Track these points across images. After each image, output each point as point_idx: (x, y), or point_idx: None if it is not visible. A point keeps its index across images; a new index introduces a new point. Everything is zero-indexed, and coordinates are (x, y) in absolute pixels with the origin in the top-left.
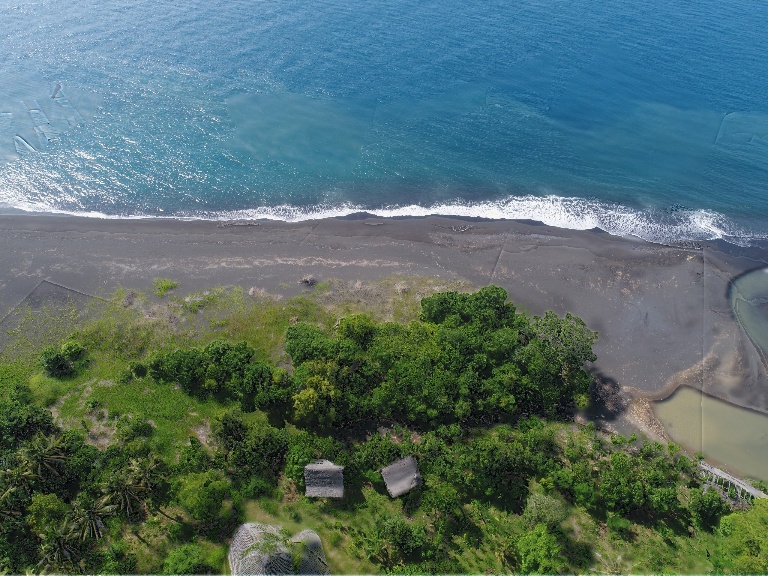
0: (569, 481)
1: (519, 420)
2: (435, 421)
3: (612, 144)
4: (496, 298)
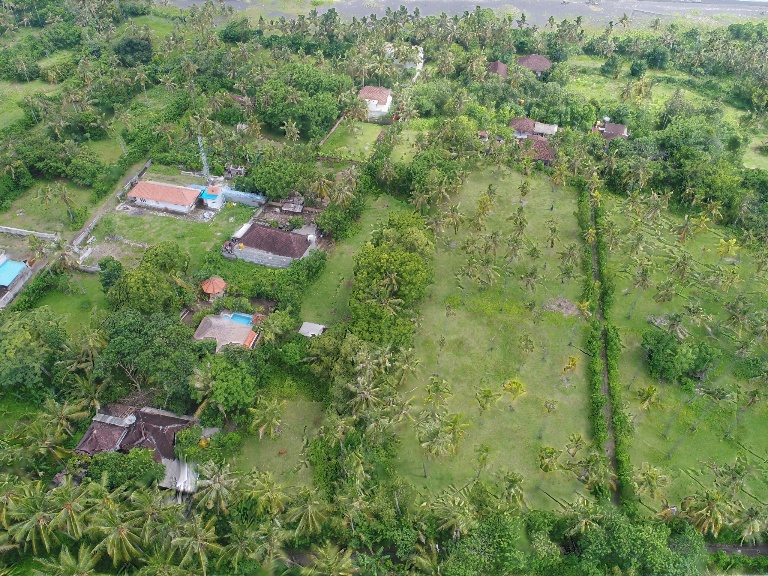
0: None
1: None
2: None
3: None
4: None
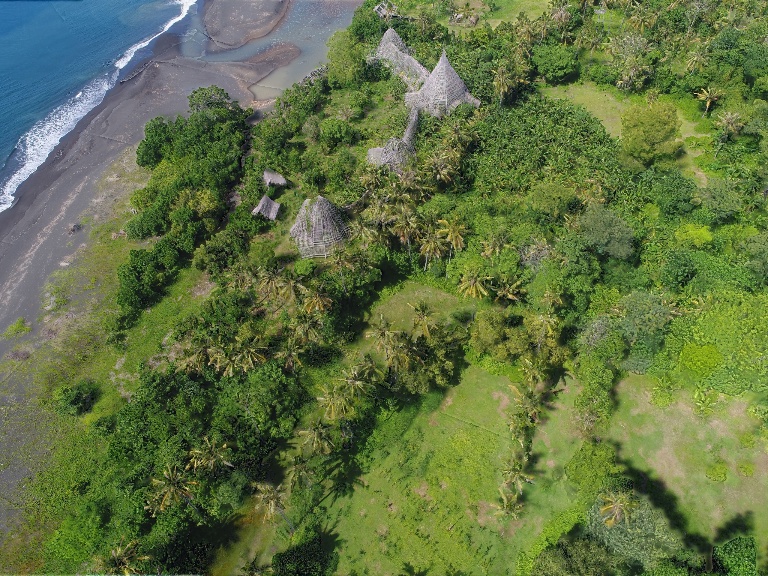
0: (296, 121)
1: (248, 144)
2: (238, 171)
3: (27, 62)
4: (160, 122)
